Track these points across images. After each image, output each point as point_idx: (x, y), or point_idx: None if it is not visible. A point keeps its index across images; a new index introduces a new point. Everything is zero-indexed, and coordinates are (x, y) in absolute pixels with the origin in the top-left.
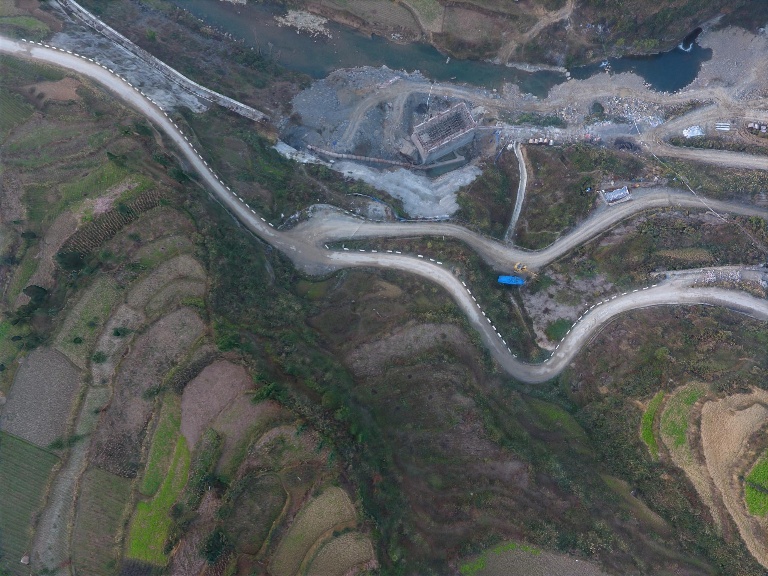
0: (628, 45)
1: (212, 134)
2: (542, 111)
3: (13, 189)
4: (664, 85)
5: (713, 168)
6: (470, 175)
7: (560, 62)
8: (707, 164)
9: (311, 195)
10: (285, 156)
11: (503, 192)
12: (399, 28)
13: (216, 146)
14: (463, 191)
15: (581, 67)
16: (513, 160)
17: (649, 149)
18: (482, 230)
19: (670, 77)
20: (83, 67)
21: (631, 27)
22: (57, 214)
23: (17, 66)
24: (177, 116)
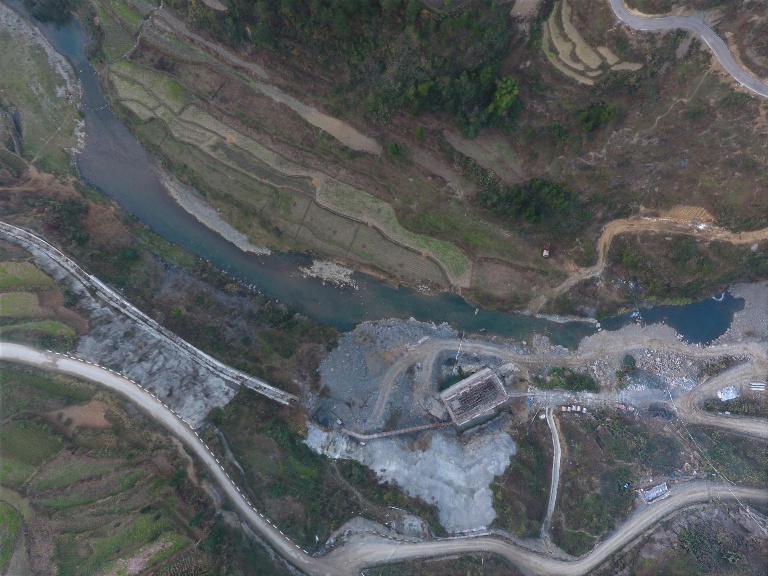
0: (660, 300)
1: (242, 433)
2: (573, 365)
3: (42, 536)
4: (696, 335)
5: (750, 442)
6: (504, 456)
7: (591, 314)
8: (744, 436)
9: (345, 509)
10: (316, 451)
11: (538, 479)
12: (427, 280)
13: (246, 450)
14: (498, 482)
15: (612, 318)
16: (546, 432)
17: (684, 417)
18: (519, 537)
19: (702, 326)
20: (110, 380)
21: (664, 289)
22: (89, 571)
23: (43, 386)
24: (208, 436)
